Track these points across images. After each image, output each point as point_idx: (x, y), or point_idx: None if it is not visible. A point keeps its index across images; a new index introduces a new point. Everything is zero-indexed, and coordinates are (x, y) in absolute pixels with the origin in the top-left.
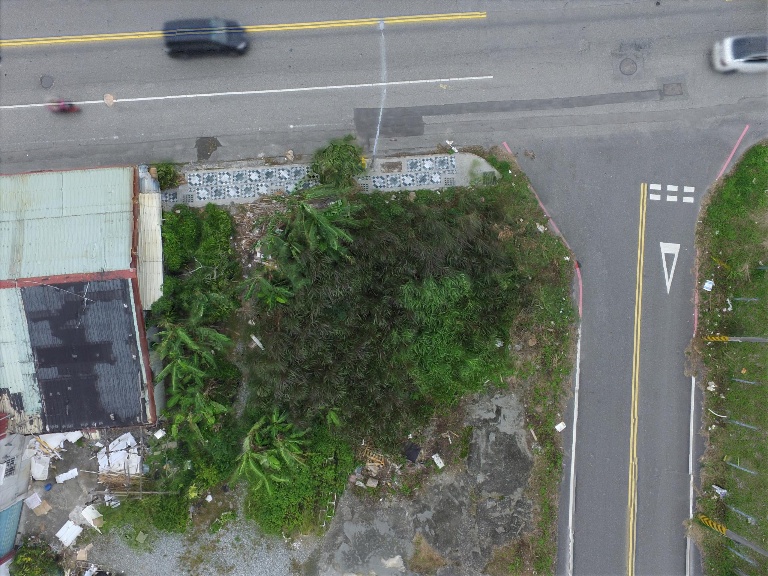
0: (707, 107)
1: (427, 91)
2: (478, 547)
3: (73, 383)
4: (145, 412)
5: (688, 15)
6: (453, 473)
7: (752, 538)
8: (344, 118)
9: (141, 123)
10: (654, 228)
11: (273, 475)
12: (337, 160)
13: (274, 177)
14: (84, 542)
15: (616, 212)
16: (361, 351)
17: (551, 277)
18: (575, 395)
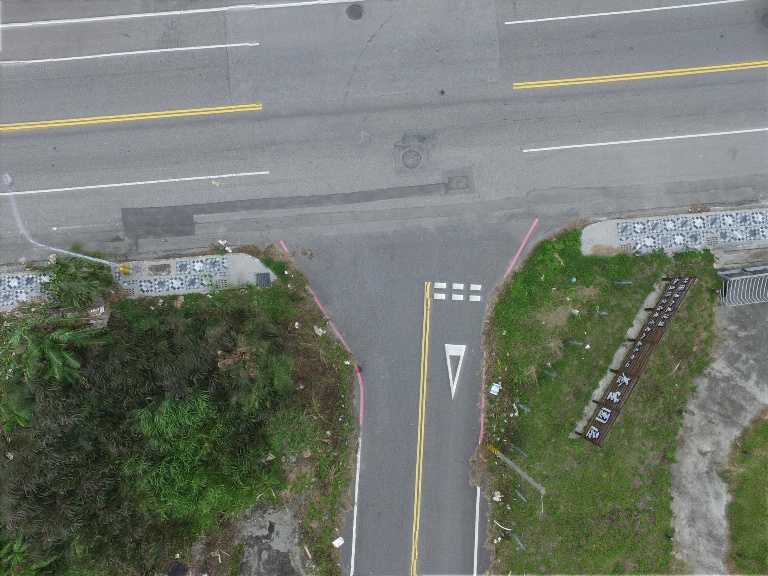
0: (494, 200)
1: (199, 189)
2: None
3: None
4: None
5: (474, 104)
6: None
7: None
8: (111, 218)
9: None
10: (438, 329)
11: None
12: (62, 281)
13: (34, 283)
14: None
15: (398, 313)
16: (96, 480)
17: (329, 383)
18: (354, 508)
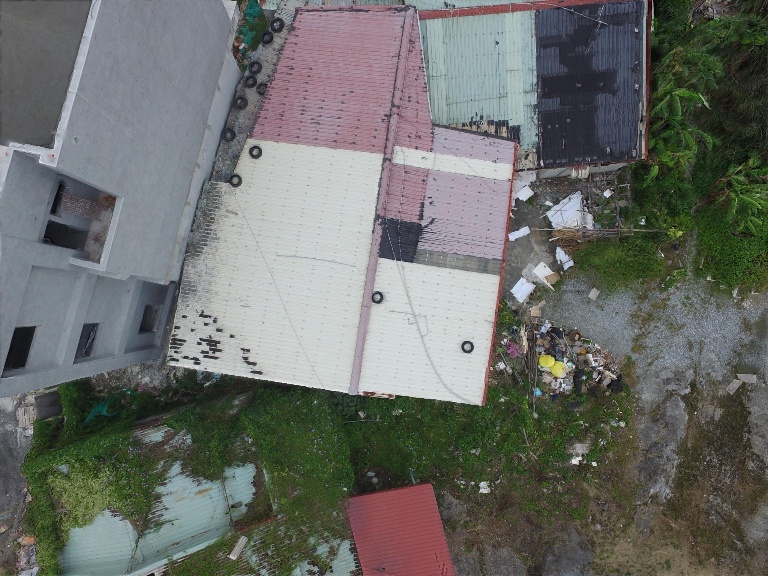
0: None
1: None
2: None
3: (573, 114)
4: (641, 145)
5: None
6: None
7: None
8: None
9: None
10: None
11: (754, 217)
12: None
13: None
14: (537, 299)
15: None
16: None
17: None
18: None
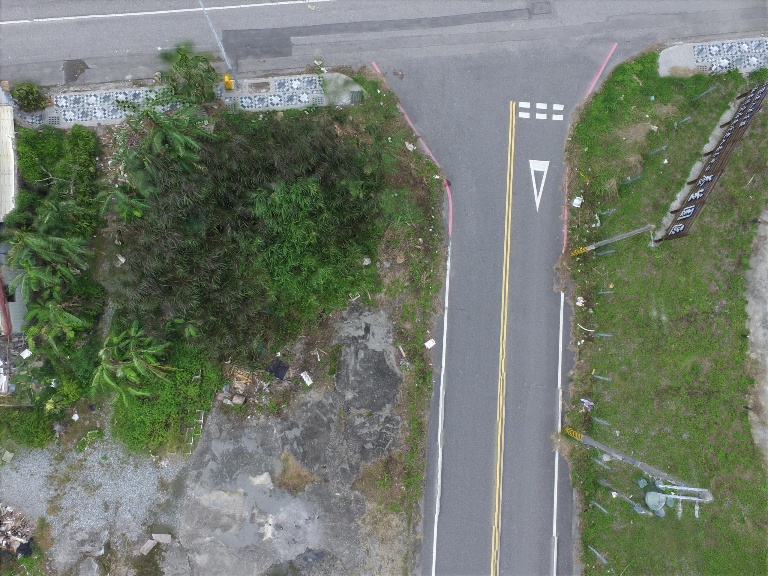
0: (576, 25)
1: (295, 12)
2: (346, 463)
3: None
4: None
5: None
6: (321, 390)
7: (620, 451)
8: (212, 40)
9: (8, 46)
10: (523, 146)
11: (131, 388)
12: (183, 68)
13: (141, 98)
14: None
15: (485, 130)
16: (213, 260)
17: (420, 195)
18: (445, 312)
